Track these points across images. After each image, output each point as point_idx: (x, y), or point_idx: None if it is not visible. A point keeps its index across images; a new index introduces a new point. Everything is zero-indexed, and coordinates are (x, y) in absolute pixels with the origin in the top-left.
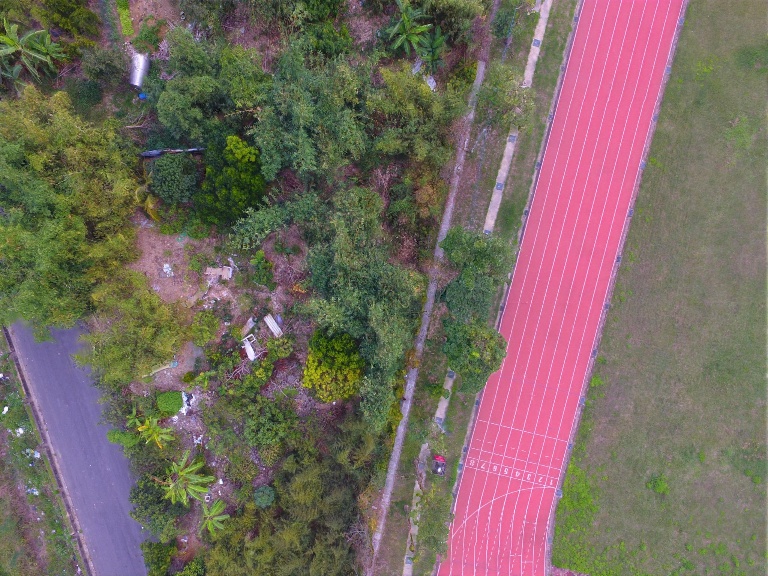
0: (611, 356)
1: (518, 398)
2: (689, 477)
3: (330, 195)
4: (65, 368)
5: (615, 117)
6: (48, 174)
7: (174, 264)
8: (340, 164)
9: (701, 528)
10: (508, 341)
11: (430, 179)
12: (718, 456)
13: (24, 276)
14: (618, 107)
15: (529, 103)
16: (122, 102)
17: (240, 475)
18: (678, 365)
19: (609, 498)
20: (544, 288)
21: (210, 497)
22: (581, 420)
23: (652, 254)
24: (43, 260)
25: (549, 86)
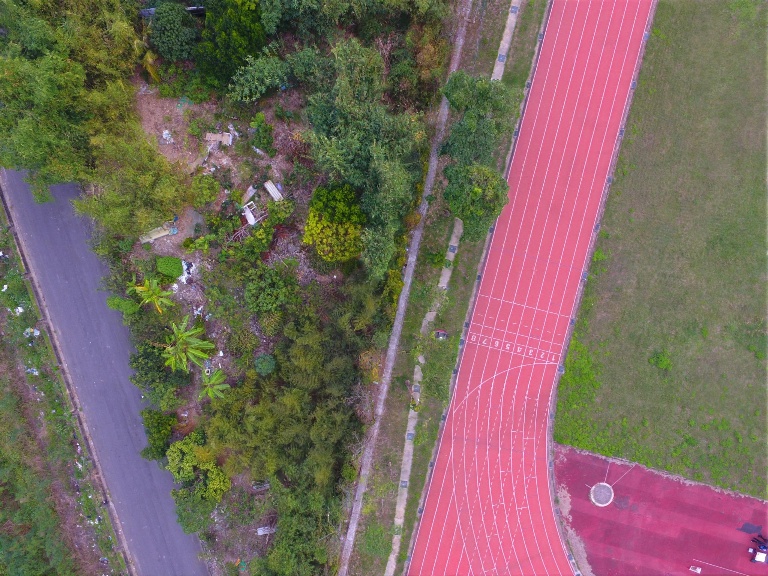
0: (614, 230)
1: (520, 273)
2: (692, 353)
3: None
4: (64, 244)
5: None
6: (46, 18)
7: (174, 131)
8: (341, 9)
9: (704, 404)
10: (510, 215)
11: (432, 40)
12: (721, 331)
13: (22, 118)
14: None
15: None
16: None
17: (240, 344)
18: (681, 239)
19: (611, 374)
20: (546, 161)
21: (210, 370)
22: (583, 295)
23: (655, 127)
24: (41, 88)
25: None
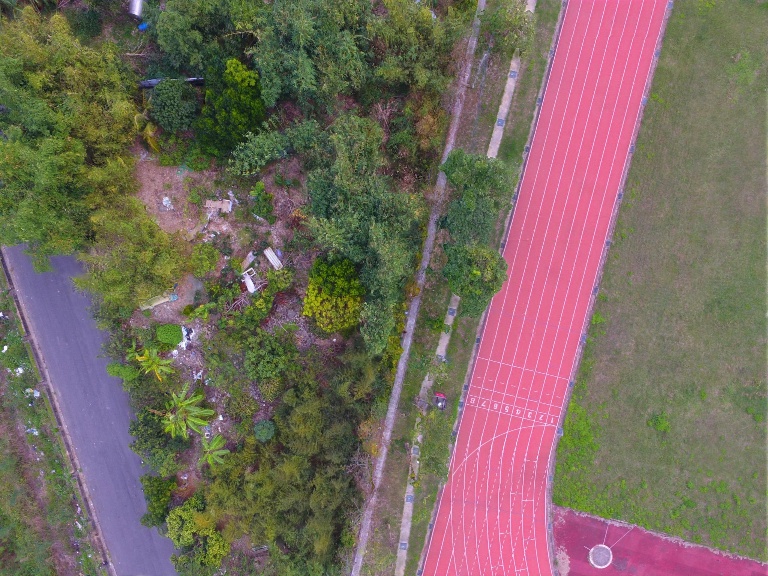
0: (612, 293)
1: (519, 335)
2: (690, 415)
3: (330, 123)
4: (64, 306)
5: (617, 53)
6: (47, 96)
7: (174, 197)
8: (340, 87)
9: (702, 466)
10: (509, 278)
11: (431, 110)
12: (719, 394)
13: (23, 197)
14: (620, 42)
15: (530, 24)
16: (121, 34)
17: (240, 409)
18: (679, 302)
19: (610, 436)
20: (545, 225)
21: (210, 434)
22: (582, 358)
23: (654, 191)
24: (42, 174)
25: (550, 21)
